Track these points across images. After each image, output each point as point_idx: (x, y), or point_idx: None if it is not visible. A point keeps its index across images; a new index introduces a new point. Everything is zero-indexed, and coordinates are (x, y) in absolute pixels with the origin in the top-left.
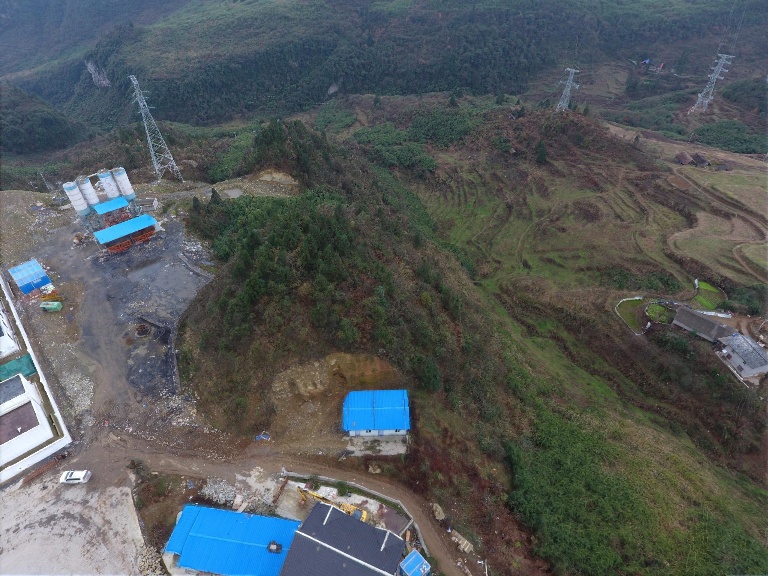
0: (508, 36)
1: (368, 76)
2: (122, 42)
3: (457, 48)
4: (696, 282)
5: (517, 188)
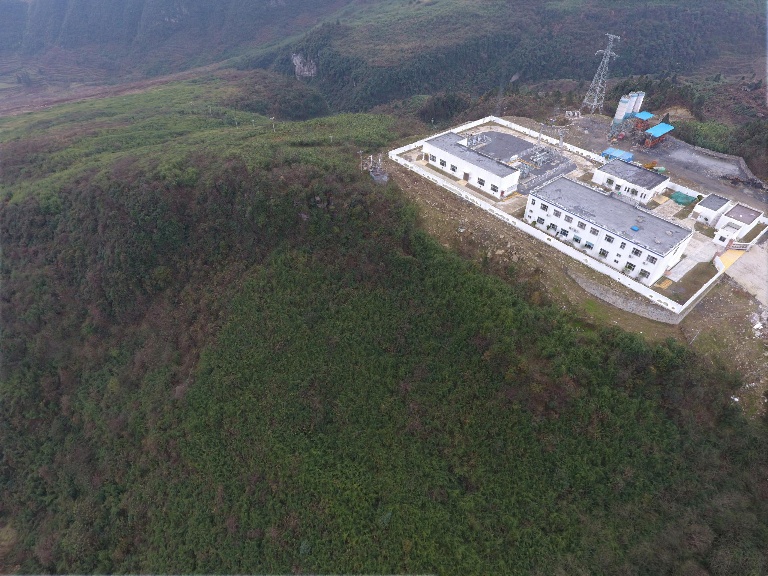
0: (678, 30)
1: (547, 66)
2: (331, 37)
3: (634, 40)
4: None
5: None
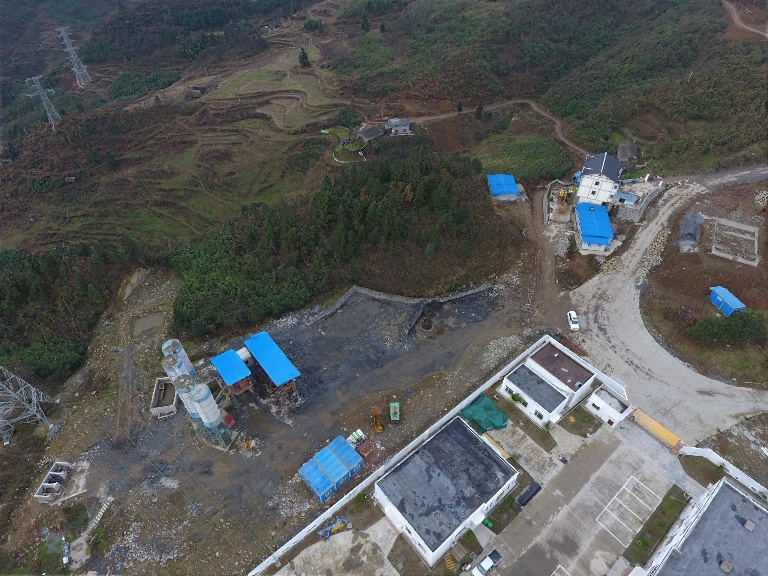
0: None
1: None
2: None
3: None
4: (324, 132)
5: (137, 192)
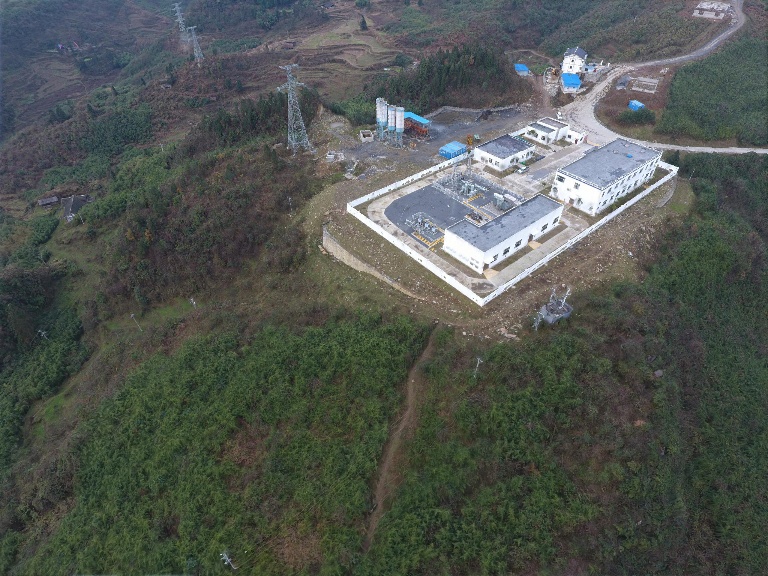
0: None
1: None
2: None
3: None
4: (386, 69)
5: None
